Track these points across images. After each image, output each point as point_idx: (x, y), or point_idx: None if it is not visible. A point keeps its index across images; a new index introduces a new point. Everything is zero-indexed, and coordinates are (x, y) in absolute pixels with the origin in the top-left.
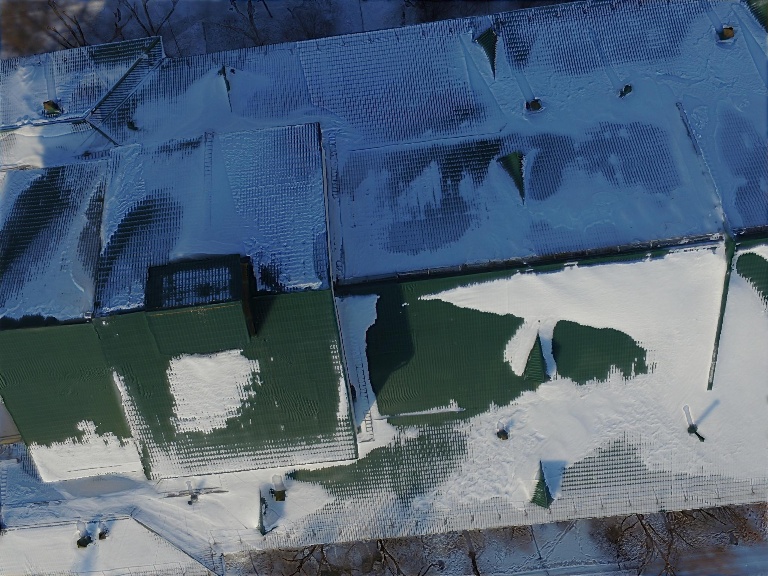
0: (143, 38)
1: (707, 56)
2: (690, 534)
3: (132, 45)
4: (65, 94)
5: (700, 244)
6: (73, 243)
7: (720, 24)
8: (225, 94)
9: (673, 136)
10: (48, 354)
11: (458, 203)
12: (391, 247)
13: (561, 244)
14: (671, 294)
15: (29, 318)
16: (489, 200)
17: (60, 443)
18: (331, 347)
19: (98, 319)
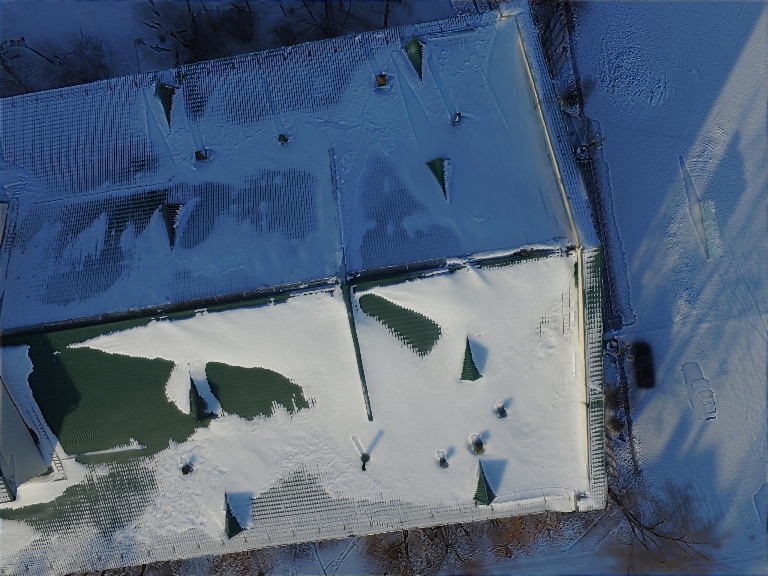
0: None
1: (364, 102)
2: (467, 549)
3: None
4: None
5: (318, 288)
6: None
7: (379, 71)
8: None
9: (320, 182)
10: None
11: (116, 253)
12: (46, 298)
13: (197, 291)
14: (304, 334)
15: None
16: (144, 249)
17: None
18: None
19: None
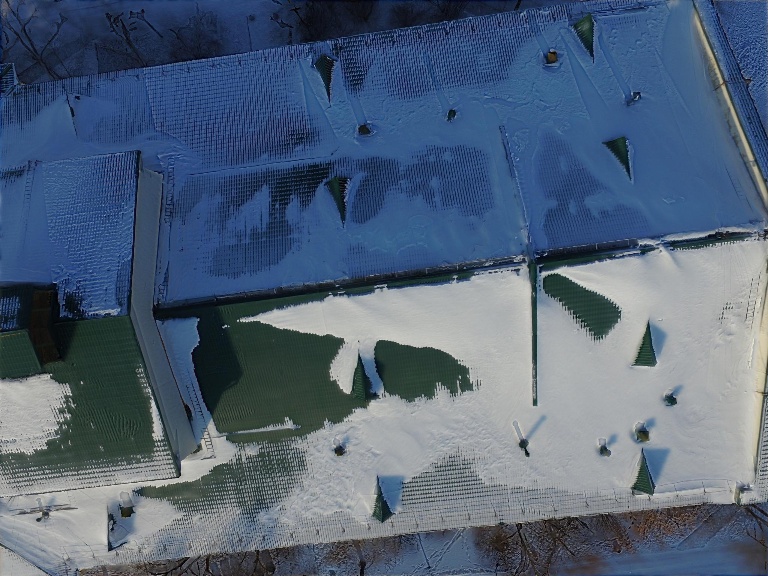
0: None
1: (533, 80)
2: (575, 542)
3: None
4: None
5: (504, 266)
6: None
7: (548, 48)
8: (70, 120)
9: (493, 159)
10: None
11: (283, 226)
12: (214, 270)
13: (374, 267)
14: (482, 314)
15: None
16: (312, 223)
17: None
18: (137, 370)
19: None
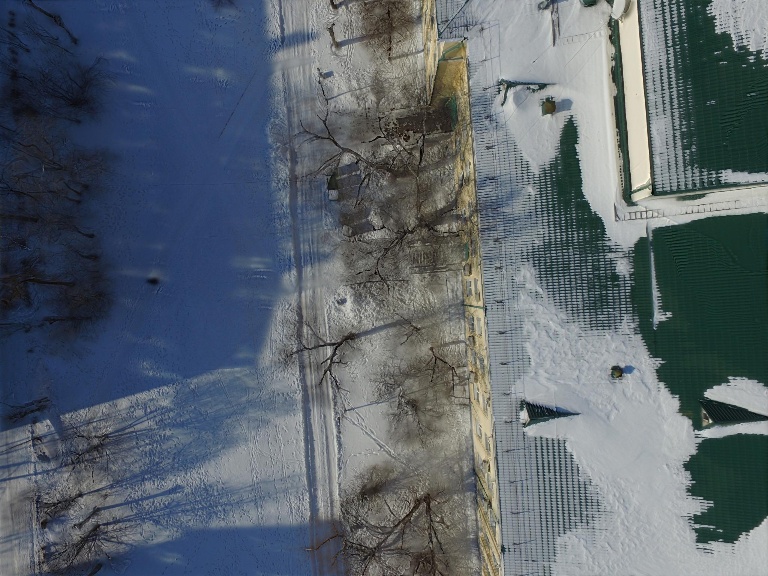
0: None
1: None
2: (368, 573)
3: None
4: None
5: None
6: None
7: None
8: None
9: None
10: None
11: None
12: None
13: None
14: None
15: None
16: None
17: None
18: None
19: None
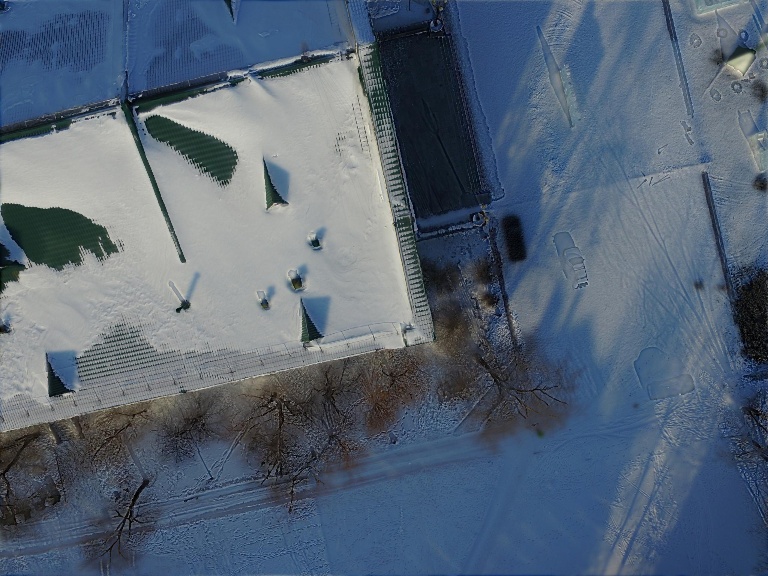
0: None
1: None
2: (352, 438)
3: None
4: None
5: (99, 111)
6: None
7: None
8: None
9: (113, 18)
10: None
11: None
12: None
13: None
14: (94, 165)
15: None
16: None
17: None
18: None
19: None
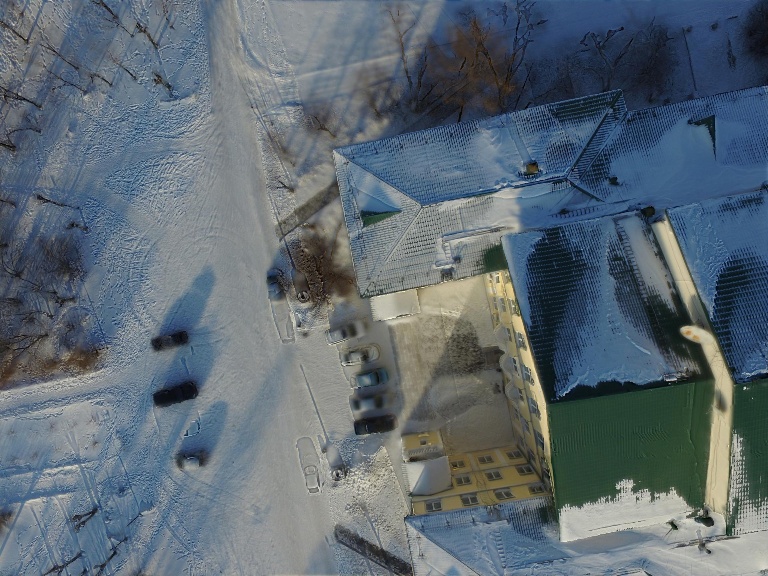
0: (604, 93)
1: None
2: None
3: (595, 100)
4: (539, 154)
5: None
6: (613, 305)
7: None
8: (709, 144)
9: None
10: (608, 418)
11: None
12: None
13: None
14: None
15: (606, 385)
16: None
17: (592, 503)
18: None
19: (740, 385)
